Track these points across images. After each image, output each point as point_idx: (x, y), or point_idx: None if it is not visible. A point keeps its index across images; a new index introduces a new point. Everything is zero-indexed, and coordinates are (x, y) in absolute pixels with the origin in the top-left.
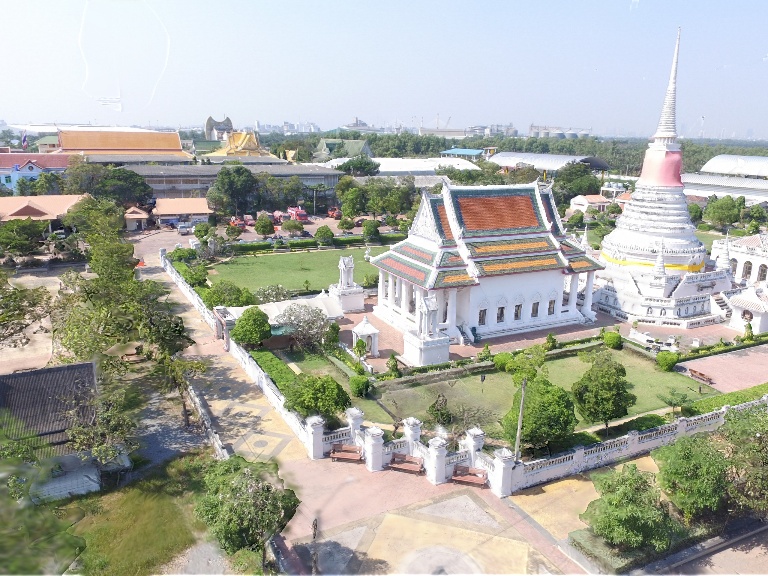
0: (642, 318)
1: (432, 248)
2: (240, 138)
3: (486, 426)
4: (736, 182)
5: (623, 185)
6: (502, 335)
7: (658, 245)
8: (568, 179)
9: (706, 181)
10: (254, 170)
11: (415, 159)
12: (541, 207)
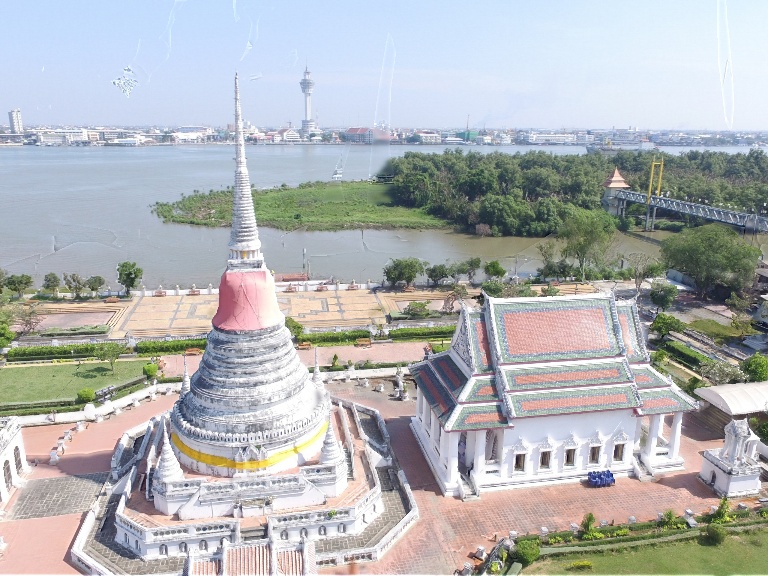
0: None
1: None
2: None
3: None
4: None
5: None
6: None
7: None
8: None
9: None
10: None
11: None
12: None
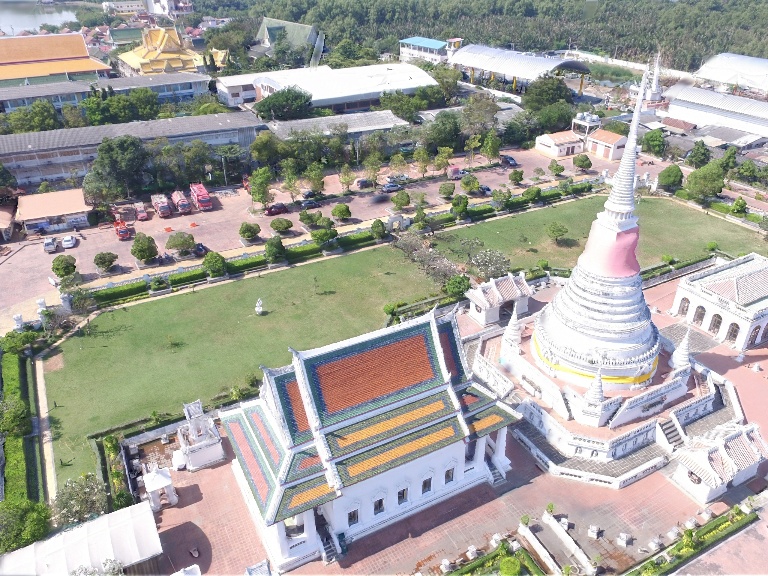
0: (566, 472)
1: (282, 440)
2: (158, 36)
3: None
4: (732, 104)
5: (599, 113)
6: (382, 527)
7: (598, 353)
8: (537, 99)
9: (698, 99)
10: (148, 131)
11: (359, 74)
12: (438, 348)
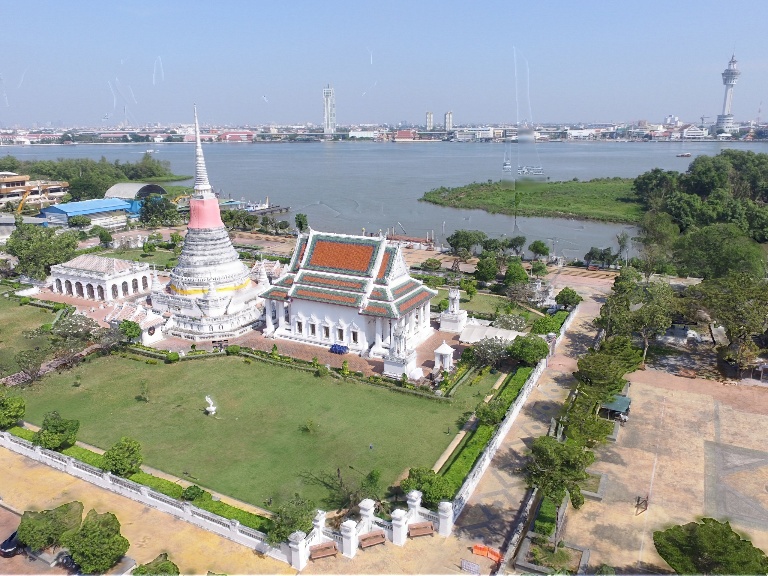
0: None
1: None
2: None
3: None
4: None
5: None
6: None
7: None
8: None
9: None
10: None
11: None
12: None
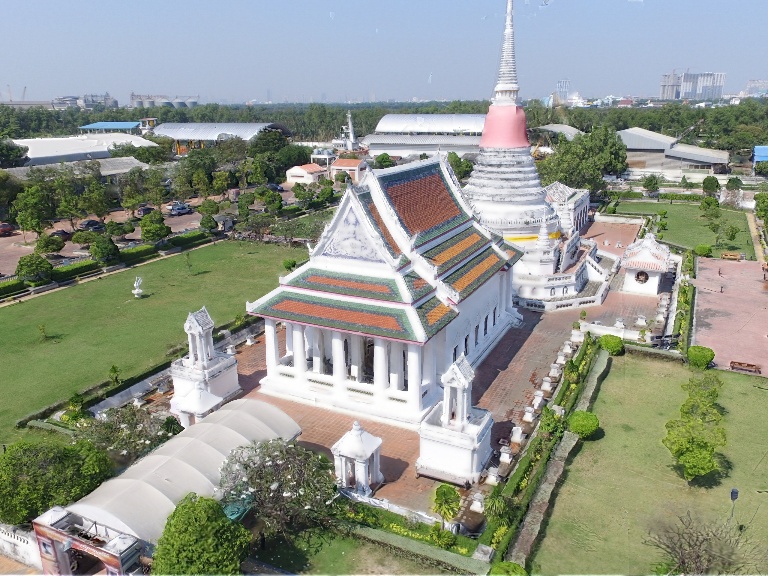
0: (561, 303)
1: (377, 273)
2: None
3: (745, 568)
4: (420, 139)
5: None
6: None
7: (528, 215)
8: (266, 149)
9: (392, 141)
10: None
11: None
12: (453, 187)
